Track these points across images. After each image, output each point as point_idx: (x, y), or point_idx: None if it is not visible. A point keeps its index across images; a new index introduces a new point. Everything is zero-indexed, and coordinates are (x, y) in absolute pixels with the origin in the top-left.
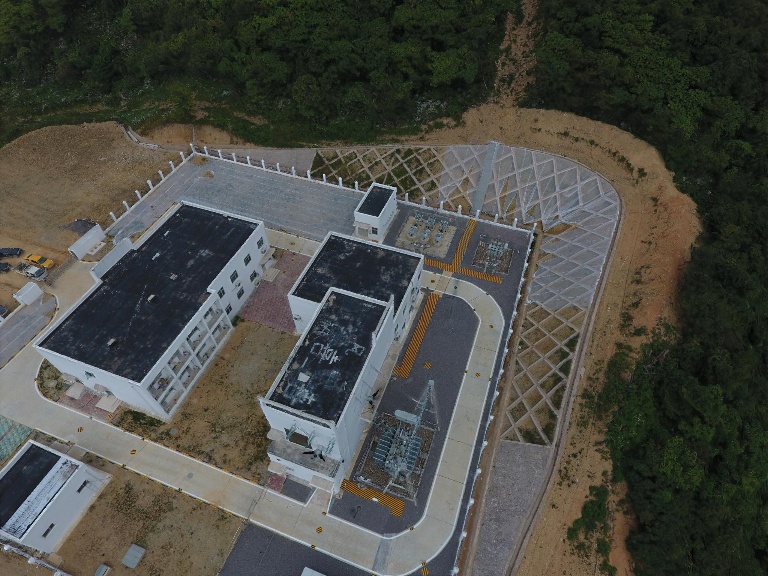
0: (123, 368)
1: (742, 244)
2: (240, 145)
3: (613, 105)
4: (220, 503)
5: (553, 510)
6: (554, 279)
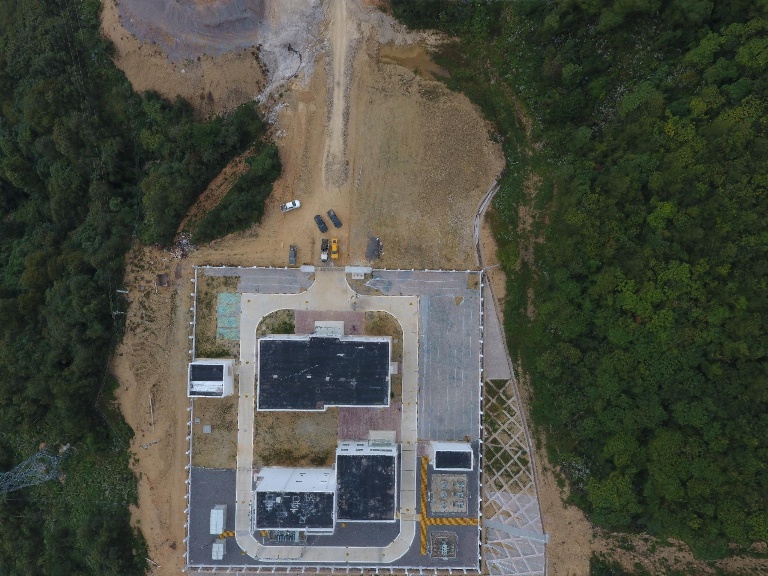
0: (265, 392)
1: None
2: (499, 308)
3: None
4: (239, 452)
5: None
6: None
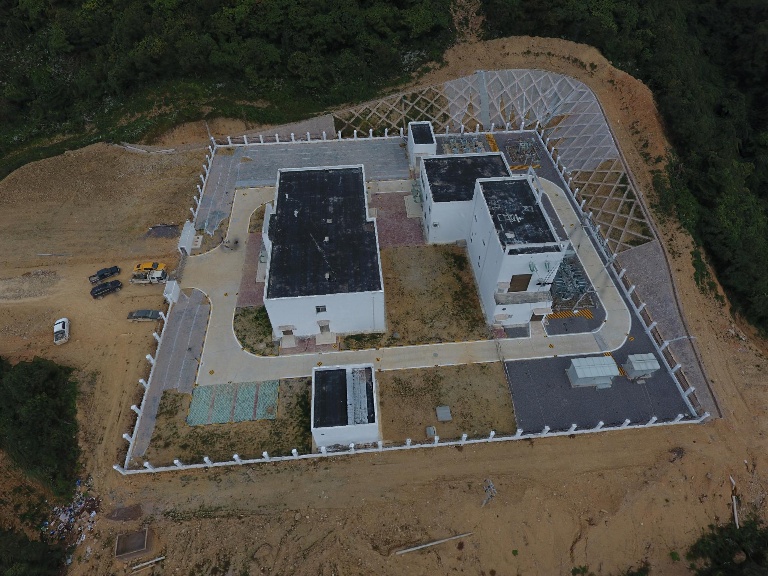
0: (353, 289)
1: (682, 91)
2: (257, 128)
3: (559, 21)
4: (472, 361)
5: (680, 273)
6: (577, 152)
